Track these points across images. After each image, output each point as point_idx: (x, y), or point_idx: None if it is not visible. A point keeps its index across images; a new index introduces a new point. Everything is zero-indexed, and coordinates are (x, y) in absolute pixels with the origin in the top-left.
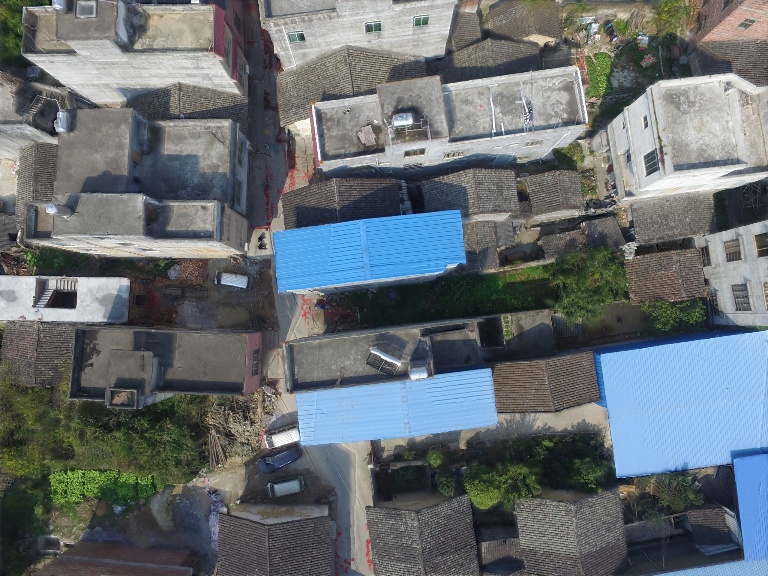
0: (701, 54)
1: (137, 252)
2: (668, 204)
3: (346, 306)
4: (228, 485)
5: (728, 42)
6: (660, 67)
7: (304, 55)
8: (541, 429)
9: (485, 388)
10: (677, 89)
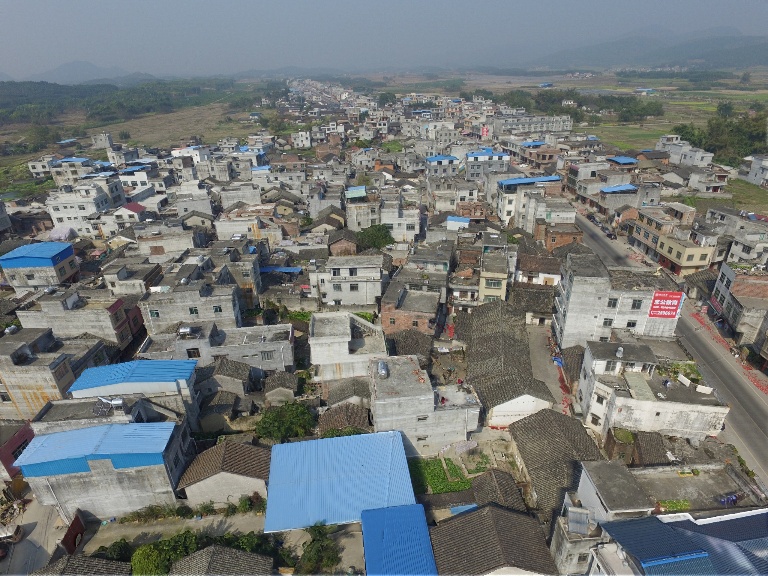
0: None
1: None
2: (345, 384)
3: None
4: None
5: (393, 333)
6: None
7: (159, 327)
8: None
9: (166, 432)
10: (324, 318)
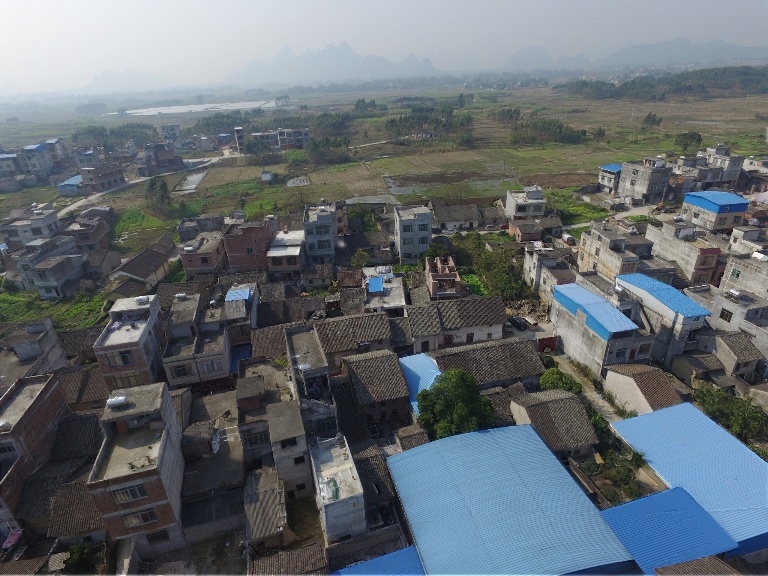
0: None
1: (589, 270)
2: None
3: None
4: None
5: None
6: None
7: (732, 287)
8: None
9: None
10: None
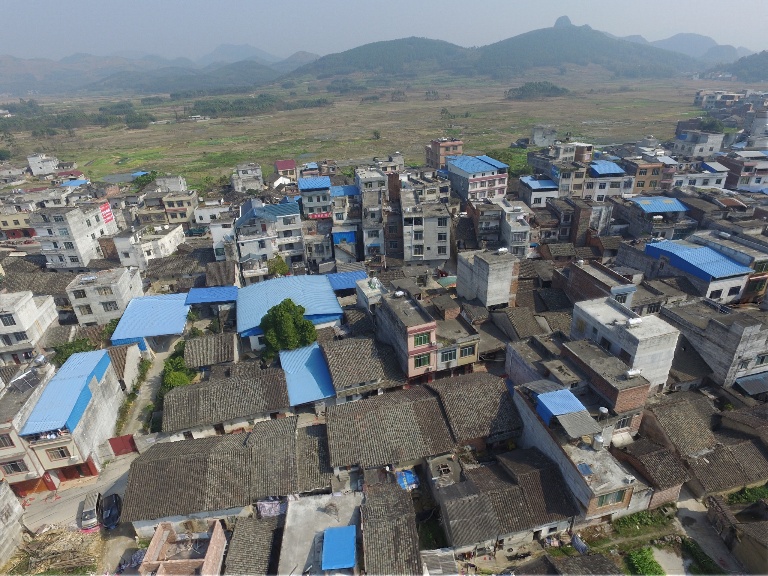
0: None
1: None
2: (51, 334)
3: None
4: (118, 553)
5: None
6: None
7: None
8: None
9: None
10: None
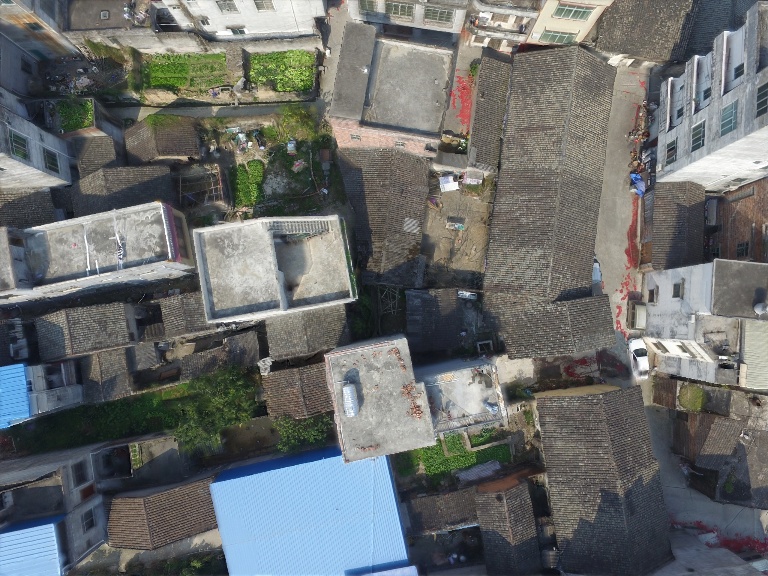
0: (340, 160)
1: None
2: (291, 321)
3: (3, 435)
4: None
5: (359, 149)
6: (310, 172)
7: None
8: (198, 547)
9: (47, 544)
10: (221, 232)
